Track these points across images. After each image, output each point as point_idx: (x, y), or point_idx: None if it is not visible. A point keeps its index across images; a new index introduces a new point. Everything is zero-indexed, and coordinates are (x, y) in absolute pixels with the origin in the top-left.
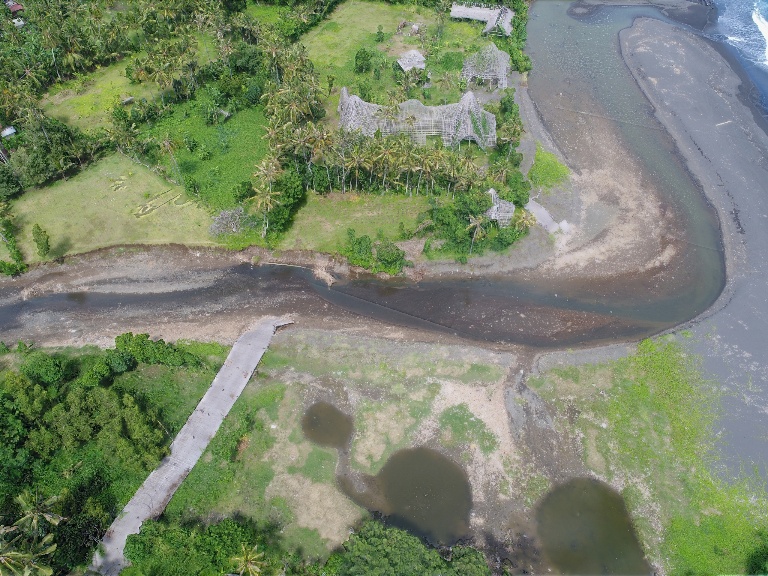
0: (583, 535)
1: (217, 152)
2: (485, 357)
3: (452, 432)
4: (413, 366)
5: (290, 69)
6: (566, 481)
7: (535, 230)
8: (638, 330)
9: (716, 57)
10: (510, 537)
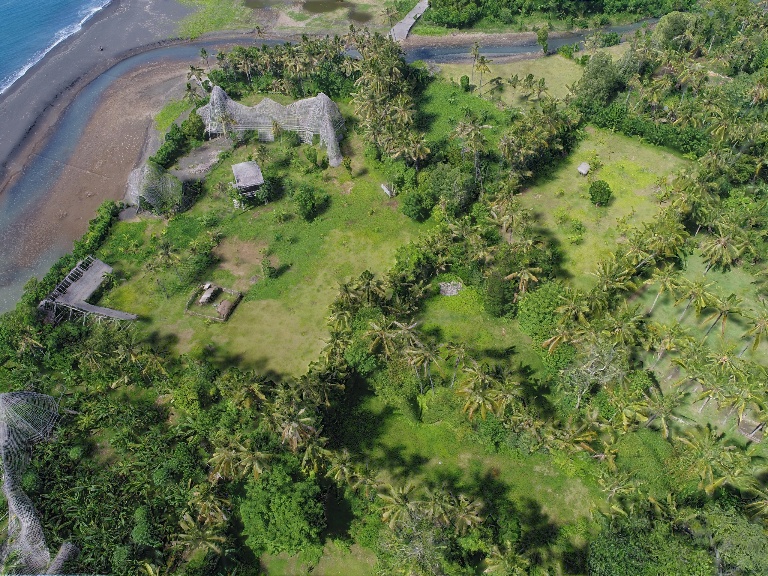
0: (265, 0)
1: (458, 120)
2: None
3: (305, 15)
4: None
5: None
6: None
7: None
8: (192, 44)
9: None
10: None
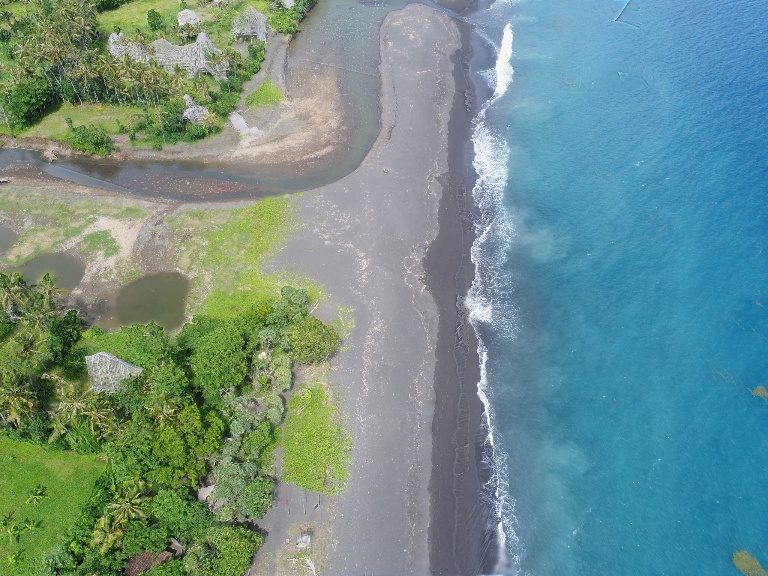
0: (149, 302)
1: (6, 76)
2: (140, 204)
3: (88, 244)
4: (82, 207)
5: (60, 10)
6: (156, 273)
7: (227, 131)
8: (270, 194)
9: (453, 31)
10: (94, 300)
